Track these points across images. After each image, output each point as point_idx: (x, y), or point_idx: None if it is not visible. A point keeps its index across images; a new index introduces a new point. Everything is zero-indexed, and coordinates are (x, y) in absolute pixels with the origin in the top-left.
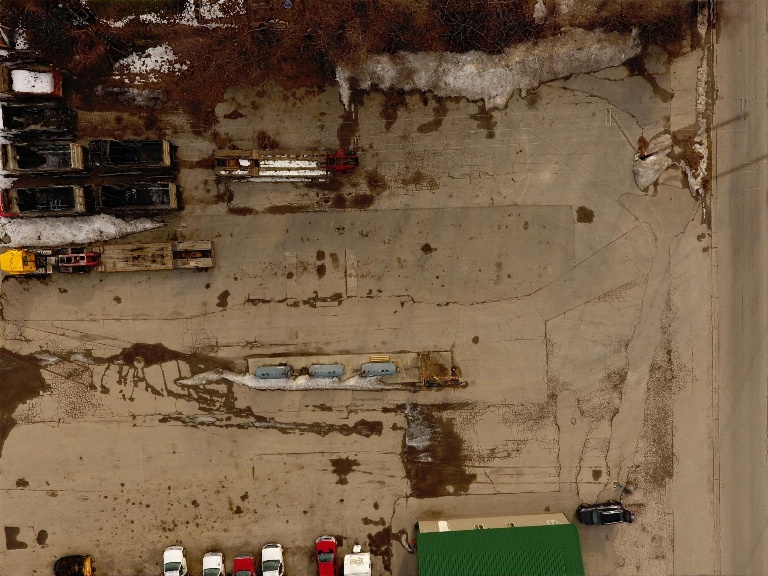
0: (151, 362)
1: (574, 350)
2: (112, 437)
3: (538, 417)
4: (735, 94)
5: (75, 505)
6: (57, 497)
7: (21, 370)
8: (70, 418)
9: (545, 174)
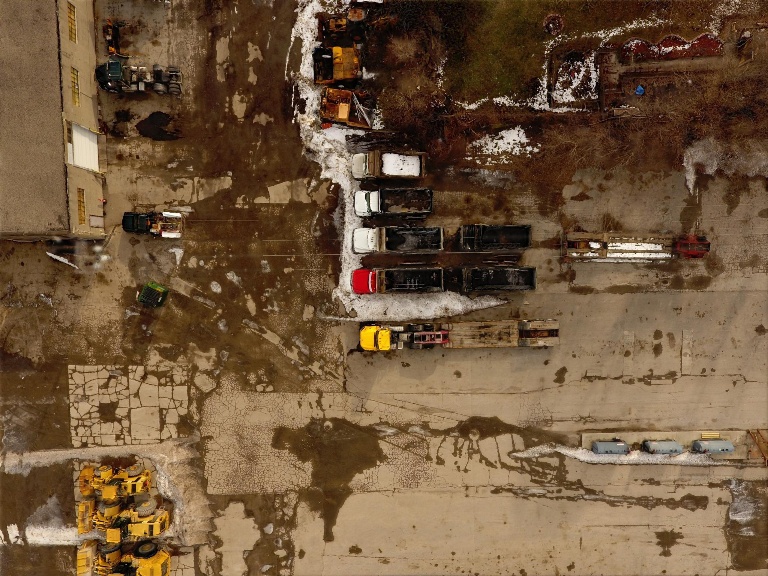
0: (486, 435)
1: None
2: (445, 507)
3: None
4: None
5: (406, 572)
6: (389, 564)
7: (360, 441)
8: (405, 488)
9: None
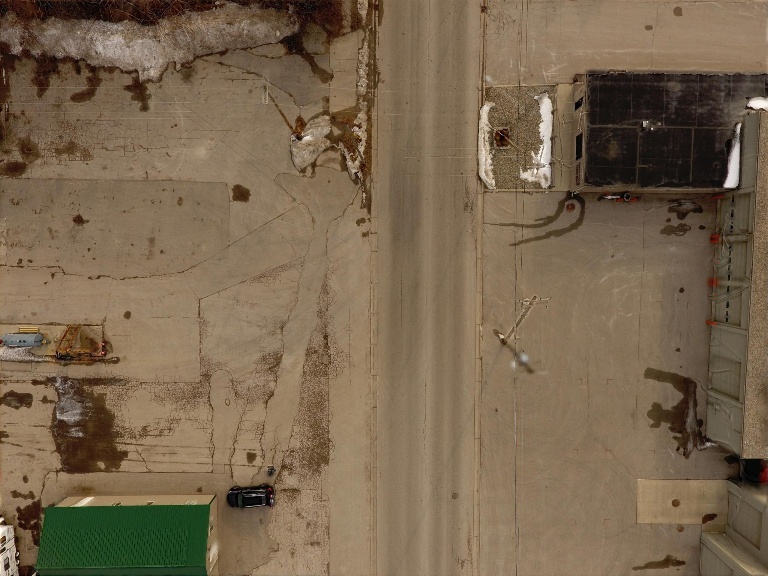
0: None
1: (228, 330)
2: None
3: (191, 396)
4: (397, 78)
5: None
6: None
7: None
8: None
9: (200, 150)
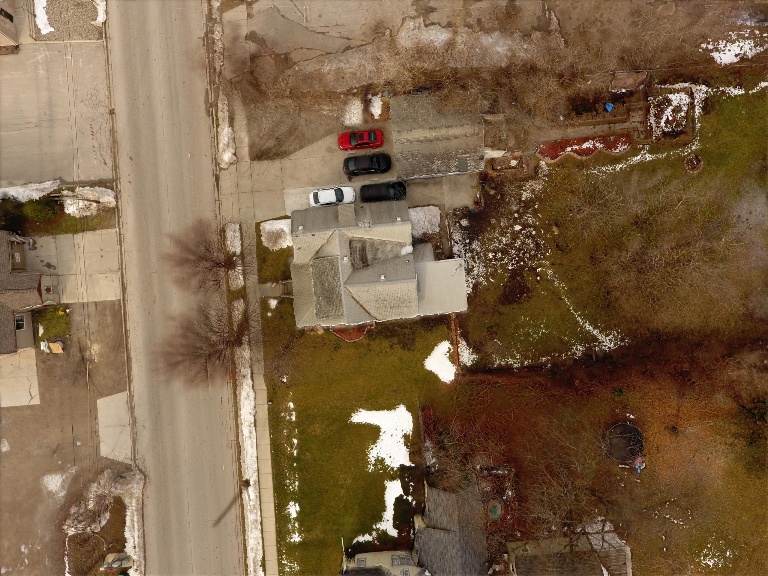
0: None
1: None
2: None
3: None
4: (187, 42)
5: None
6: None
7: None
8: None
9: None
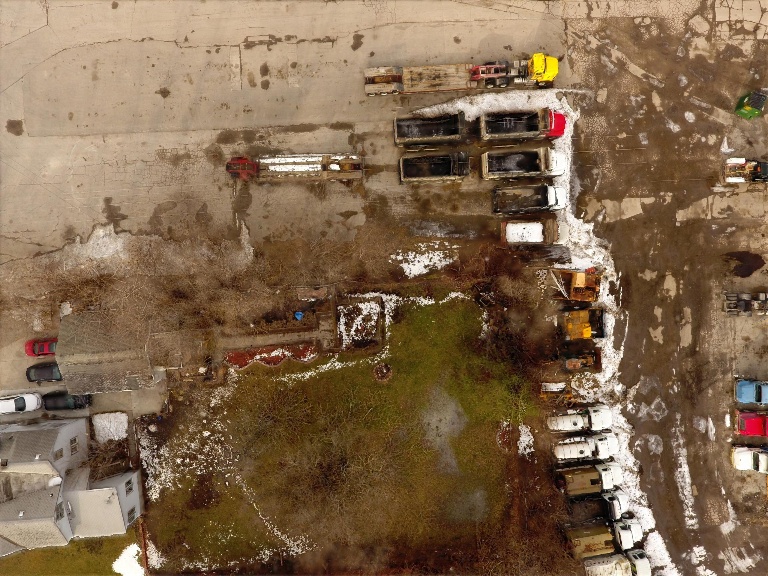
0: None
1: None
2: None
3: None
4: None
5: None
6: None
7: None
8: None
9: (55, 165)
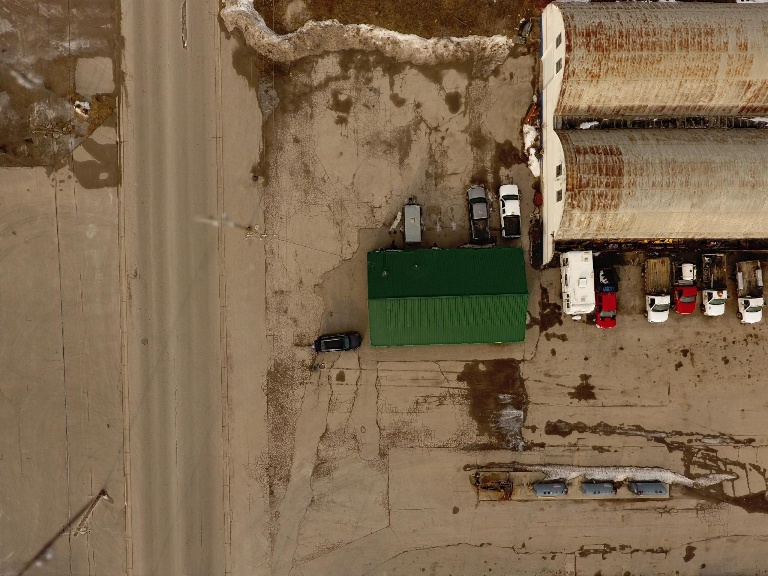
0: (759, 496)
1: (363, 498)
2: None
3: (397, 435)
4: None
5: None
6: None
7: None
8: None
9: None
